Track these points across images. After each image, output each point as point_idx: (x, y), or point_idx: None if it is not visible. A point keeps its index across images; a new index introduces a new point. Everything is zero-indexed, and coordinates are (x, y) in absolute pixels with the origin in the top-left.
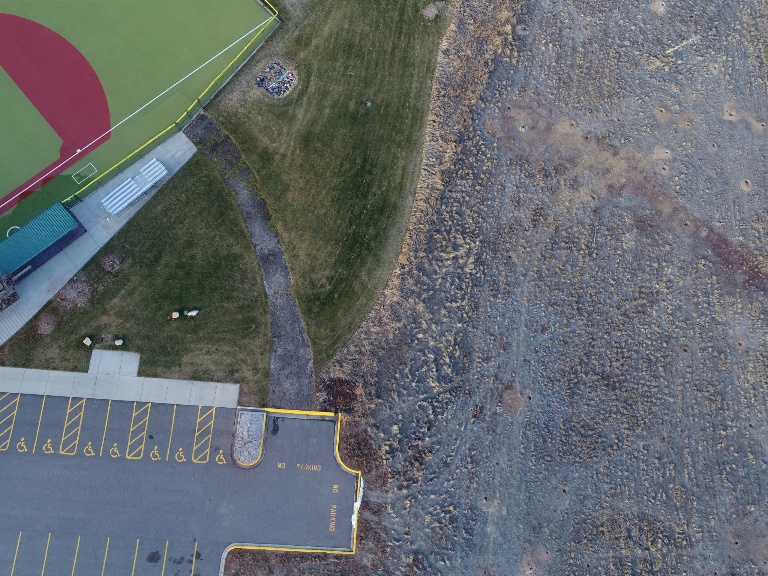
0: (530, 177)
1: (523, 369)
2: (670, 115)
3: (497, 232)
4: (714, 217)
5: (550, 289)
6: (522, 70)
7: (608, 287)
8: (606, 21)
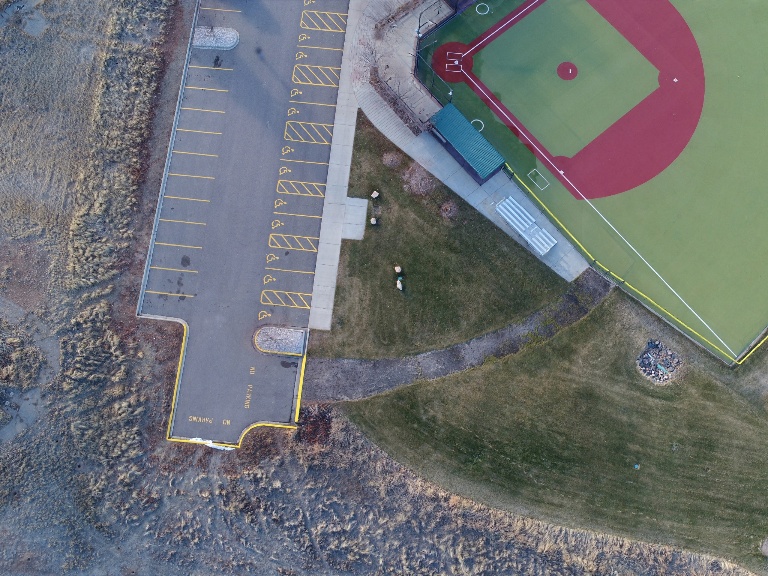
0: None
1: None
2: None
3: None
4: None
5: None
6: None
7: None
8: None
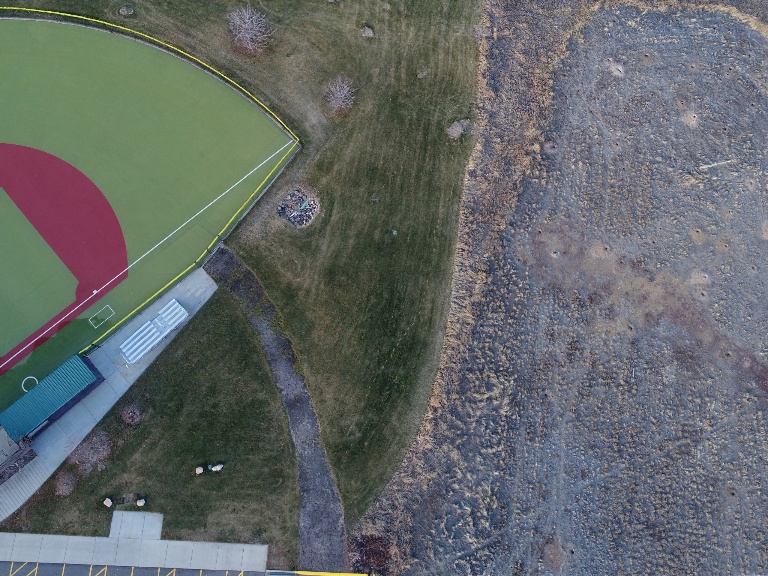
0: (564, 307)
1: (564, 520)
2: (707, 236)
3: (532, 369)
4: (757, 346)
5: (589, 430)
6: (552, 191)
7: (649, 426)
8: (637, 136)
